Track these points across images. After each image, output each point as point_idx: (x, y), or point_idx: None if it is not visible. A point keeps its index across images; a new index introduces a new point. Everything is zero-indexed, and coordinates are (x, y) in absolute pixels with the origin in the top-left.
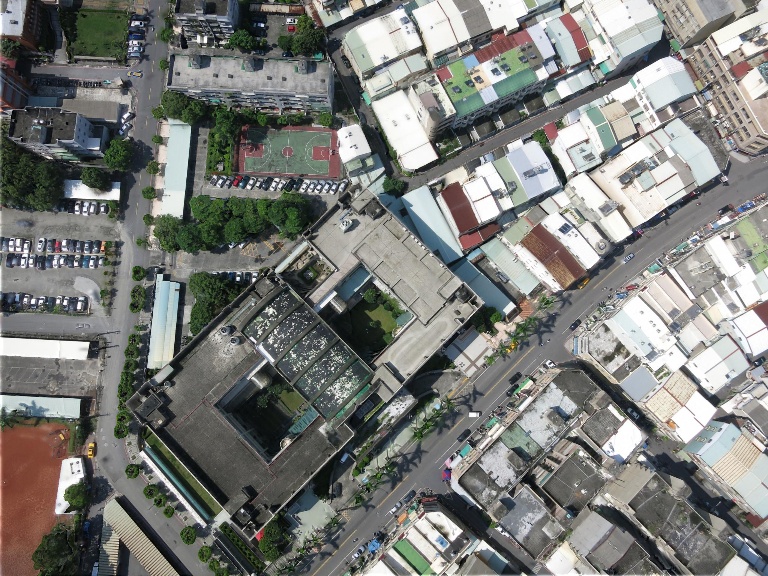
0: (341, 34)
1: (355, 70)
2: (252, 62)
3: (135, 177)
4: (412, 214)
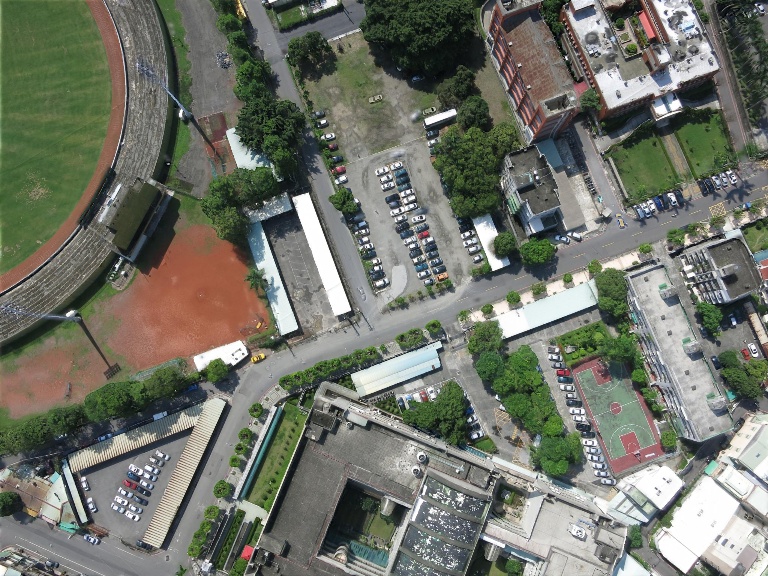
0: (766, 406)
1: (735, 440)
2: (696, 351)
3: (521, 271)
4: (615, 575)
